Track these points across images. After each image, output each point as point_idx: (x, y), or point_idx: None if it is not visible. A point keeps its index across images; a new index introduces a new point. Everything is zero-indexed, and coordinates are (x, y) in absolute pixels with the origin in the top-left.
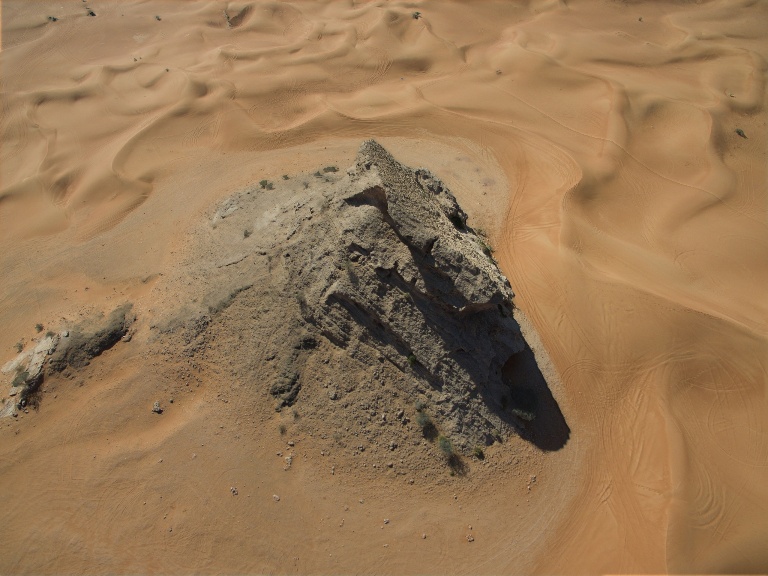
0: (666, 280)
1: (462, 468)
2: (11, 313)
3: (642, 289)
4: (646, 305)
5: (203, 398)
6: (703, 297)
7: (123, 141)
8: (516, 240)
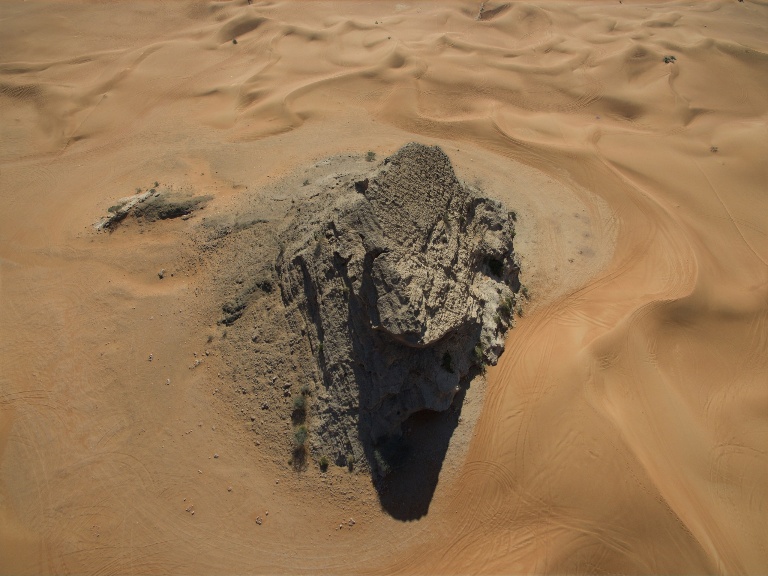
0: (678, 456)
1: (301, 464)
2: (155, 168)
3: (629, 443)
4: (617, 461)
5: (189, 284)
6: (708, 504)
7: (313, 81)
8: (556, 319)
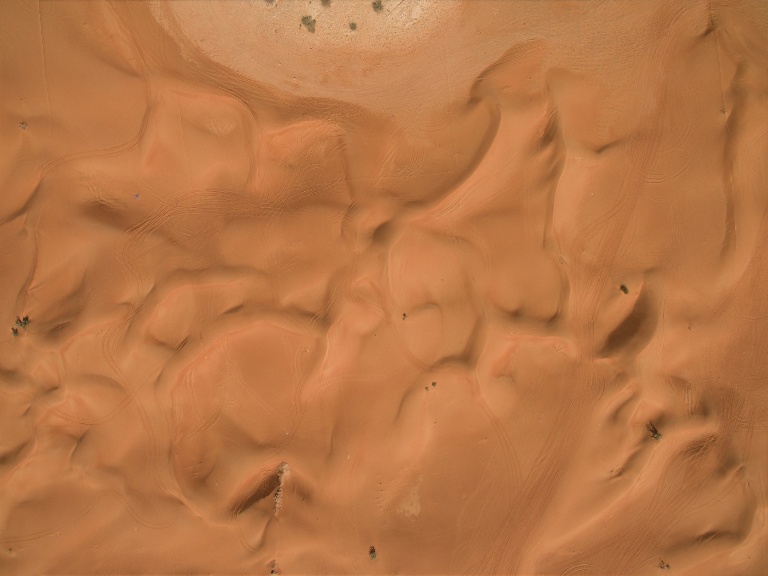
0: None
1: None
2: None
3: None
4: None
5: None
6: None
7: (483, 179)
8: None
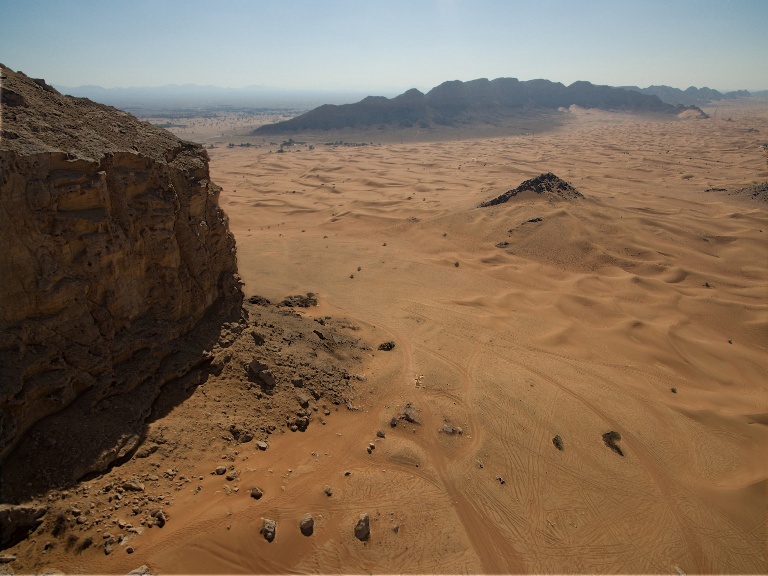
0: None
1: None
2: None
3: None
4: None
5: None
6: None
7: None
8: None
